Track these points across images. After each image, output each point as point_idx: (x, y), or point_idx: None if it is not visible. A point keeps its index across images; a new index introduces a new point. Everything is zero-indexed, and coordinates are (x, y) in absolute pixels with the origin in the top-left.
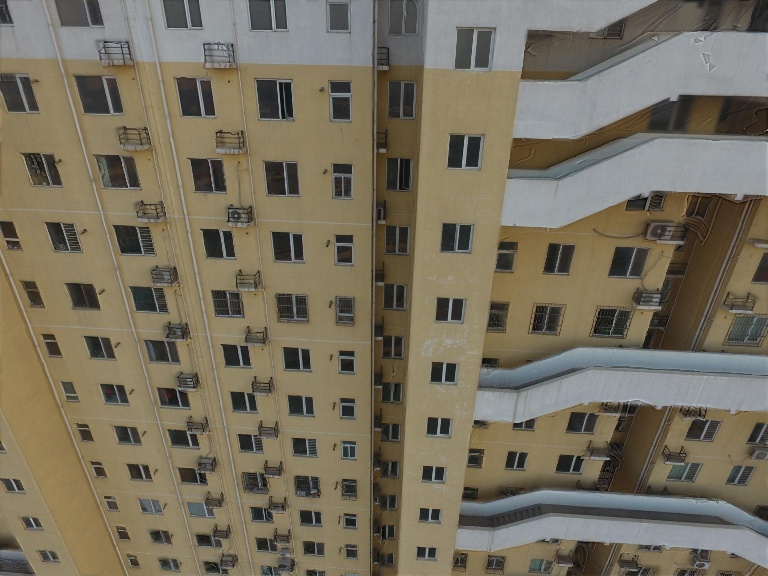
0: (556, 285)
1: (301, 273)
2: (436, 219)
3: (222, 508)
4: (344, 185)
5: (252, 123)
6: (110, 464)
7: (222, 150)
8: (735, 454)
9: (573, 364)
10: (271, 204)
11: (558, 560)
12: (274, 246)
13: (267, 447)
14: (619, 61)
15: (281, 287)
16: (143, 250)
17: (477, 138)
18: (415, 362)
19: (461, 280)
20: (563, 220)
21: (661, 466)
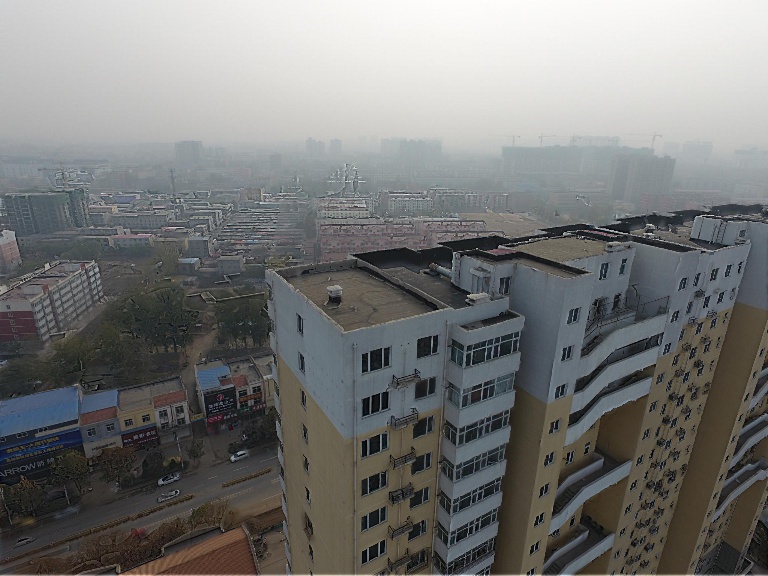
0: None
1: None
2: None
3: None
4: None
5: None
6: None
7: None
8: None
9: None
10: None
11: None
12: None
13: None
14: None
15: None
16: None
17: None
18: None
19: None
20: None
21: None
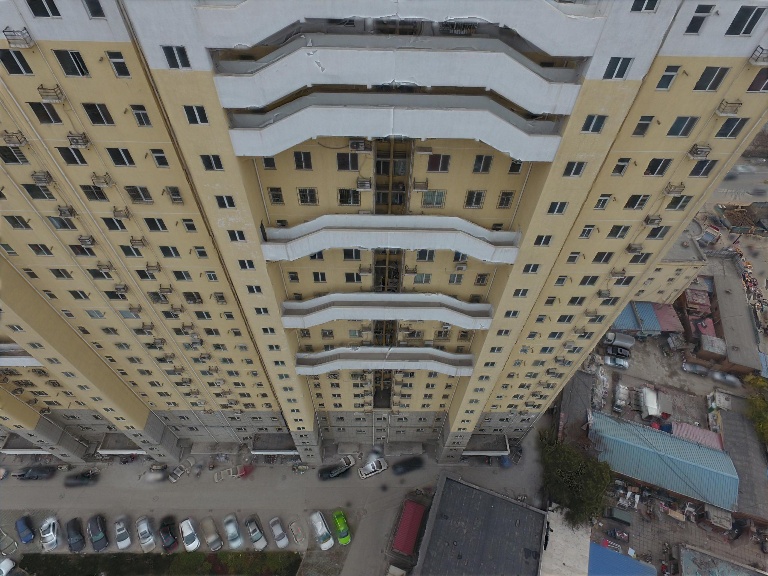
0: (306, 177)
1: (136, 173)
2: (195, 153)
3: (143, 313)
4: (143, 118)
5: (62, 79)
6: (57, 291)
7: (47, 100)
8: (449, 268)
9: (325, 224)
10: (97, 131)
11: (362, 330)
12: (111, 156)
13: (158, 277)
14: (272, 62)
15: (126, 182)
16: (20, 161)
17: (201, 107)
18: (217, 231)
19: (225, 186)
20: (272, 152)
21: (407, 276)
